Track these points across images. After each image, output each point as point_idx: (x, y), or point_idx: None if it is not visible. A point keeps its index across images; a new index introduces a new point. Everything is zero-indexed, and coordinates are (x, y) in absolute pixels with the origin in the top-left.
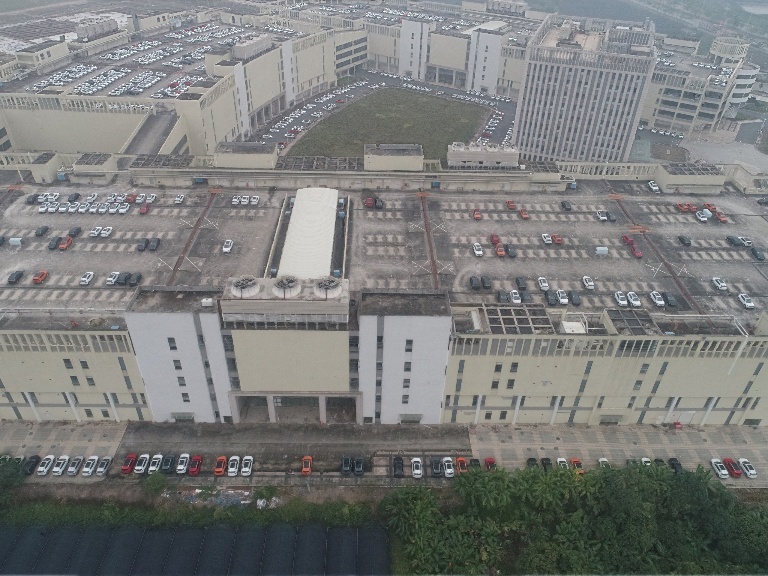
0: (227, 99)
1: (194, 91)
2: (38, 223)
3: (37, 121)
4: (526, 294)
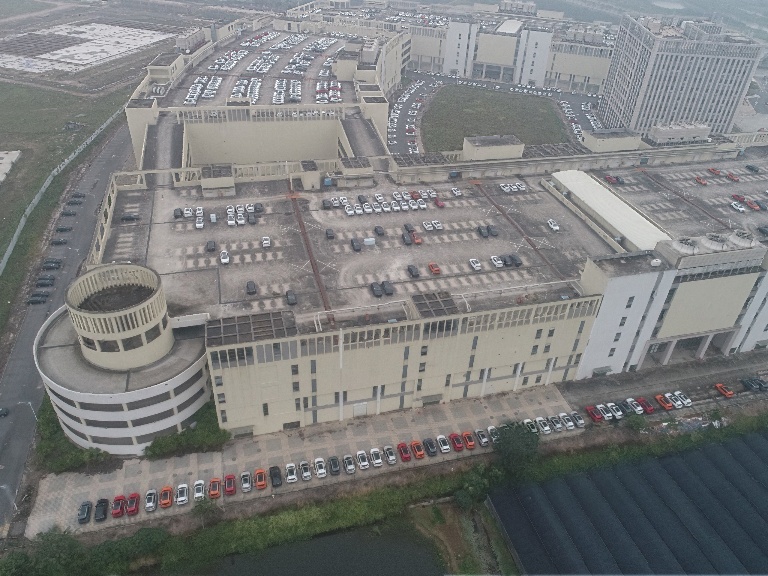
0: None
1: (365, 95)
2: (361, 225)
3: (221, 134)
4: None
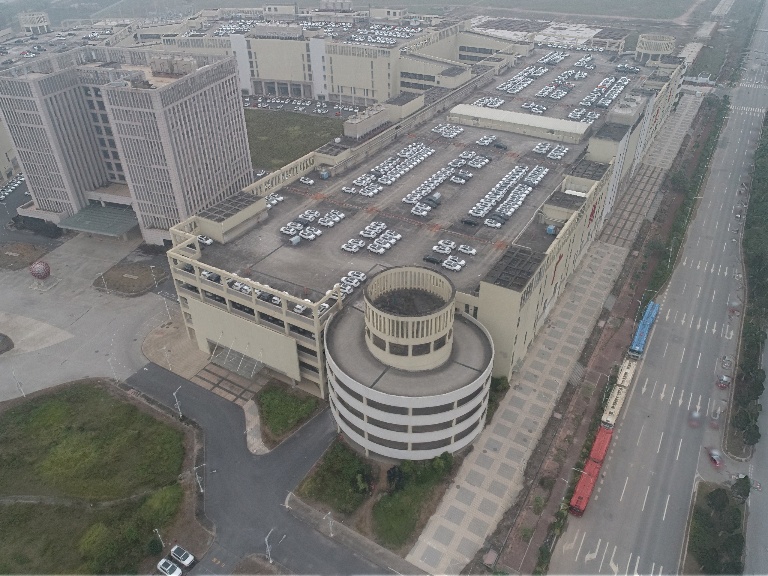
0: None
1: None
2: None
3: None
4: None
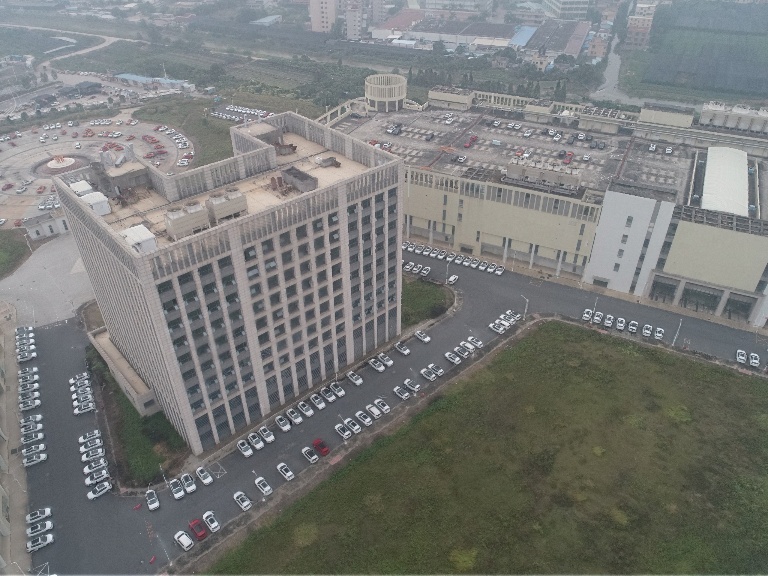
0: None
1: None
2: None
3: None
4: (576, 133)
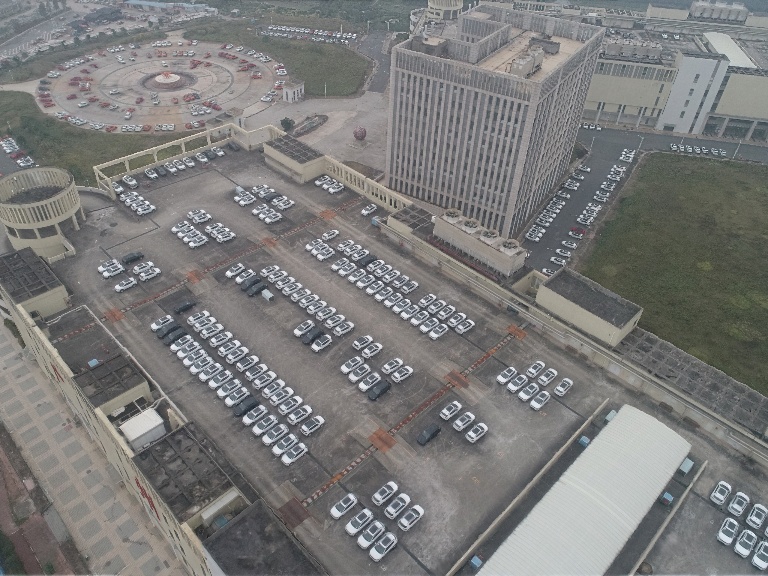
0: None
1: None
2: None
3: None
4: None
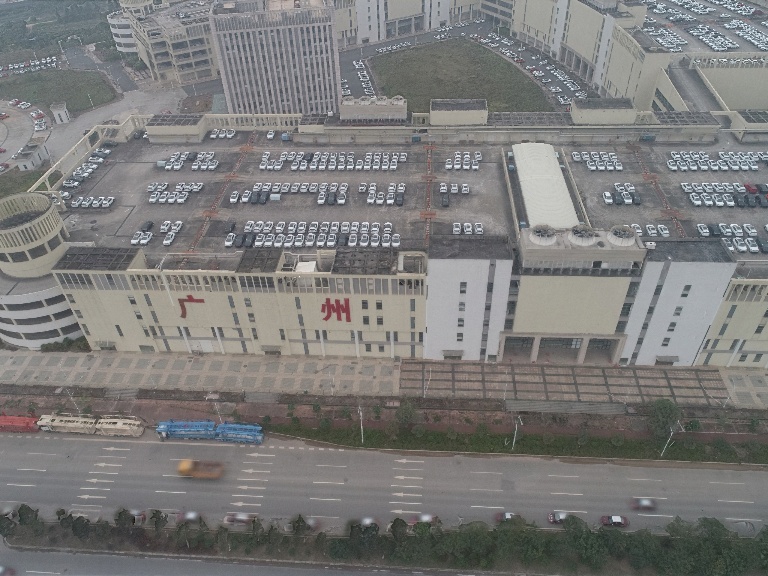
0: (546, 6)
1: None
2: None
3: None
4: None
